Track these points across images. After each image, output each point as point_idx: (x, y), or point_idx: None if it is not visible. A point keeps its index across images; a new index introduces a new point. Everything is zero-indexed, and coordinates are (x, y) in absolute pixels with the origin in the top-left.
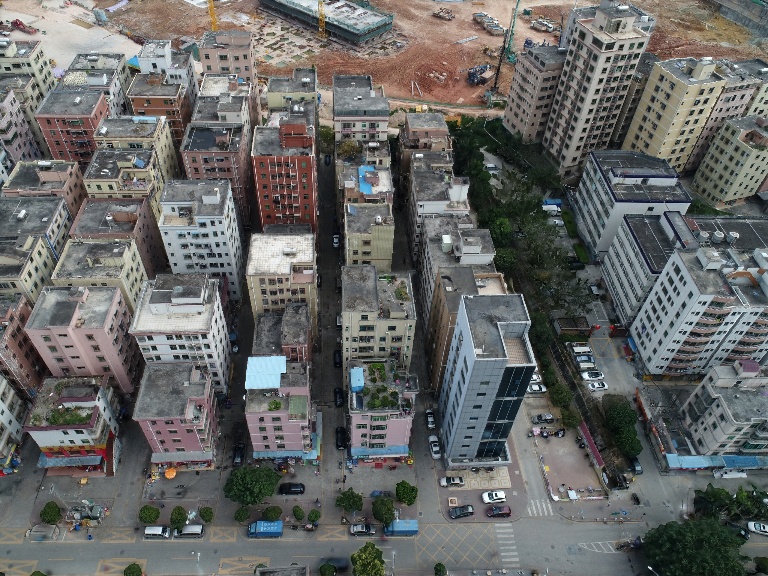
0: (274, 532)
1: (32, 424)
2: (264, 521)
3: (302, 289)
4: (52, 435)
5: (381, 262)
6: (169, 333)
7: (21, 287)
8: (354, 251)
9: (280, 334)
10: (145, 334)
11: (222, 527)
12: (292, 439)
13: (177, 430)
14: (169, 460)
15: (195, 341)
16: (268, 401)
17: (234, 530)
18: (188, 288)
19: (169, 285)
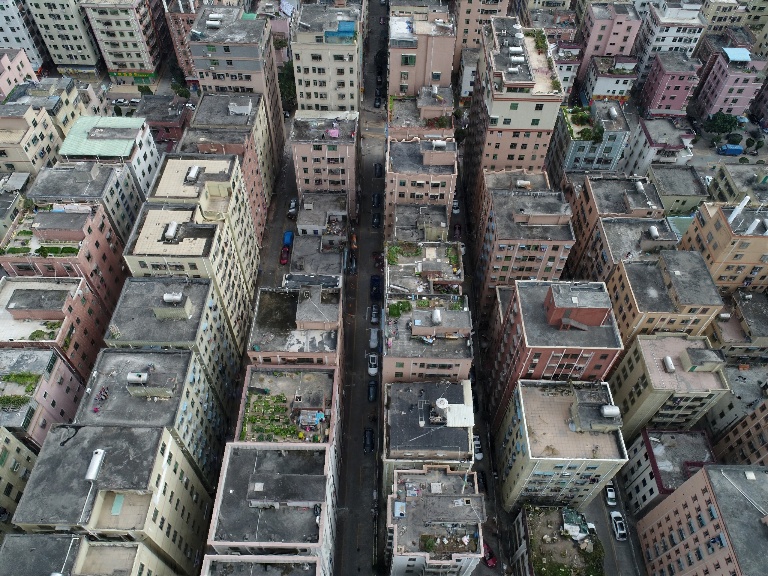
0: (739, 150)
1: (602, 74)
2: (731, 144)
3: (739, 17)
4: (608, 84)
5: (767, 18)
6: (682, 25)
7: (567, 6)
8: (753, 7)
9: (724, 45)
10: (667, 25)
11: (700, 150)
12: (741, 103)
13: (680, 87)
14: (662, 112)
15: (692, 34)
16: (740, 70)
17: (708, 151)
18: (691, 0)
19: (673, 1)
